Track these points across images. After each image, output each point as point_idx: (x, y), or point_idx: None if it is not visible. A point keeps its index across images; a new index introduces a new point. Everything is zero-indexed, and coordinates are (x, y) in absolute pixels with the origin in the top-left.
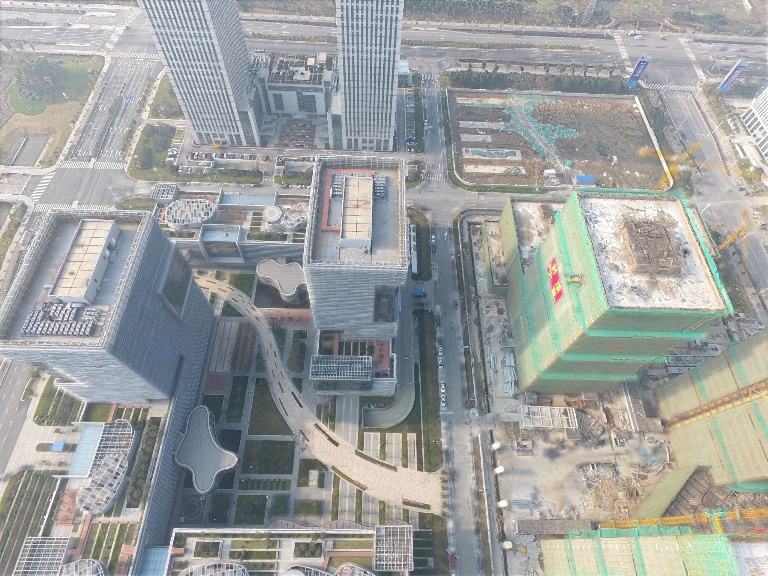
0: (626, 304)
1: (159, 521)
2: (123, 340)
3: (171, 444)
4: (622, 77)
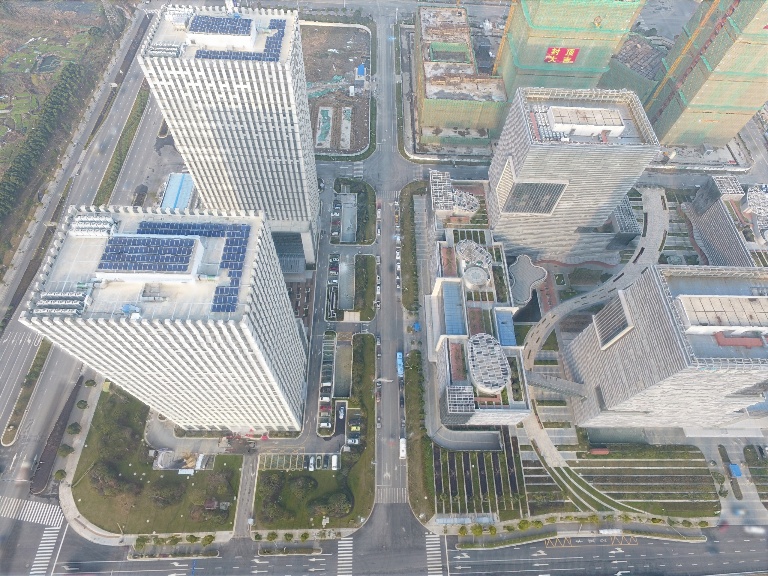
0: None
1: None
2: None
3: None
4: None
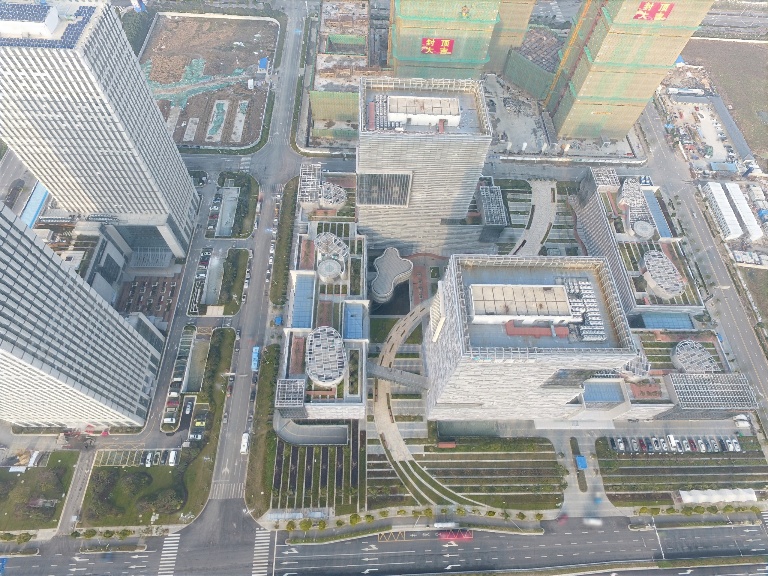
0: None
1: None
2: None
3: None
4: (129, 12)
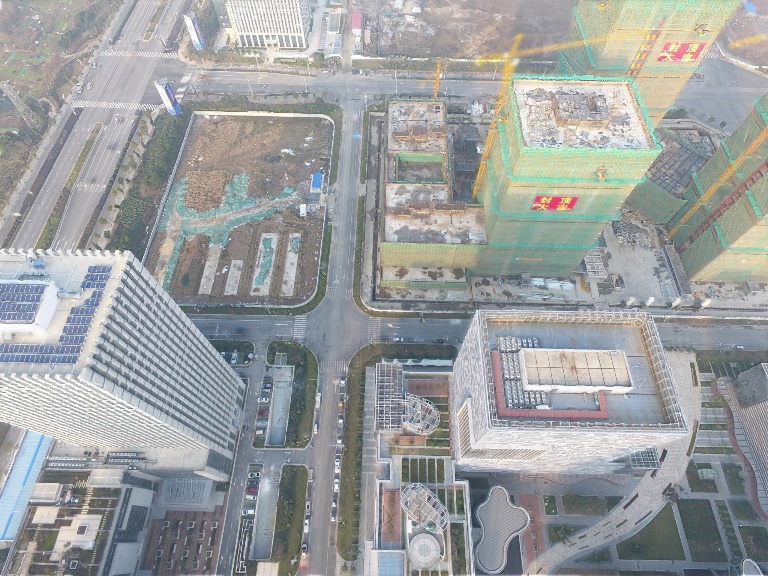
0: (642, 139)
1: None
2: None
3: None
4: (162, 115)
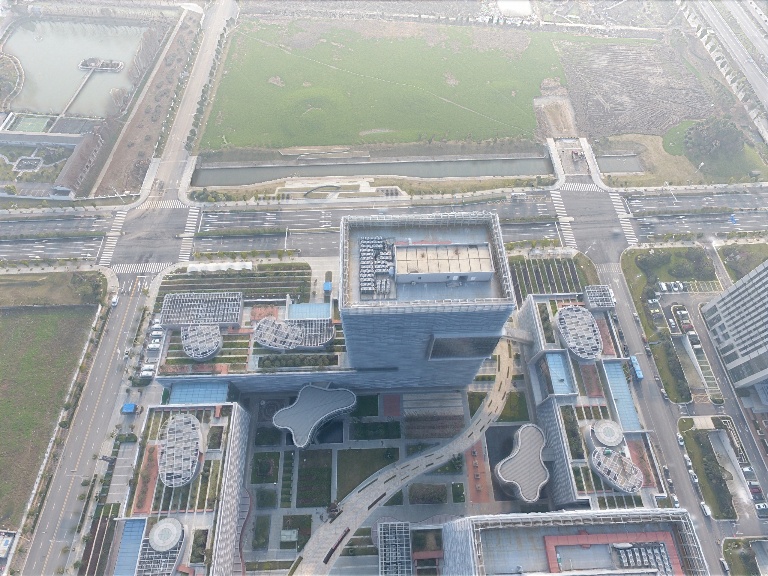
0: None
1: (254, 386)
2: (362, 321)
3: (316, 379)
4: None
